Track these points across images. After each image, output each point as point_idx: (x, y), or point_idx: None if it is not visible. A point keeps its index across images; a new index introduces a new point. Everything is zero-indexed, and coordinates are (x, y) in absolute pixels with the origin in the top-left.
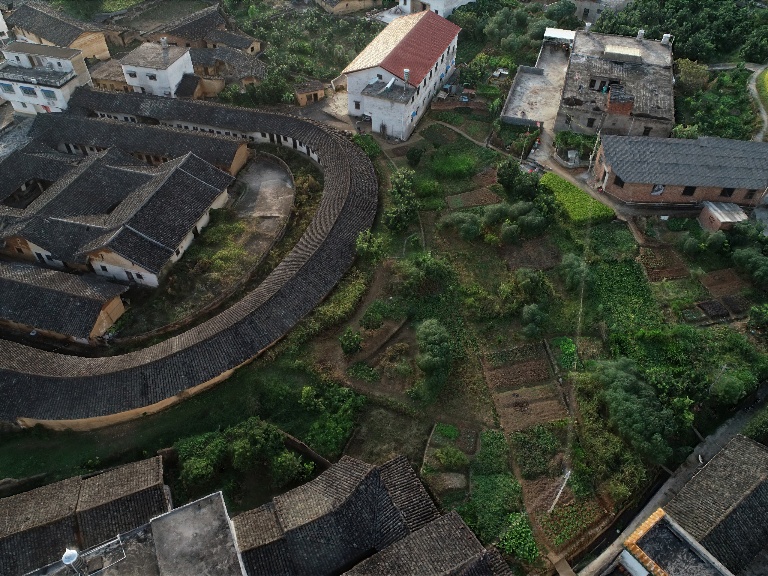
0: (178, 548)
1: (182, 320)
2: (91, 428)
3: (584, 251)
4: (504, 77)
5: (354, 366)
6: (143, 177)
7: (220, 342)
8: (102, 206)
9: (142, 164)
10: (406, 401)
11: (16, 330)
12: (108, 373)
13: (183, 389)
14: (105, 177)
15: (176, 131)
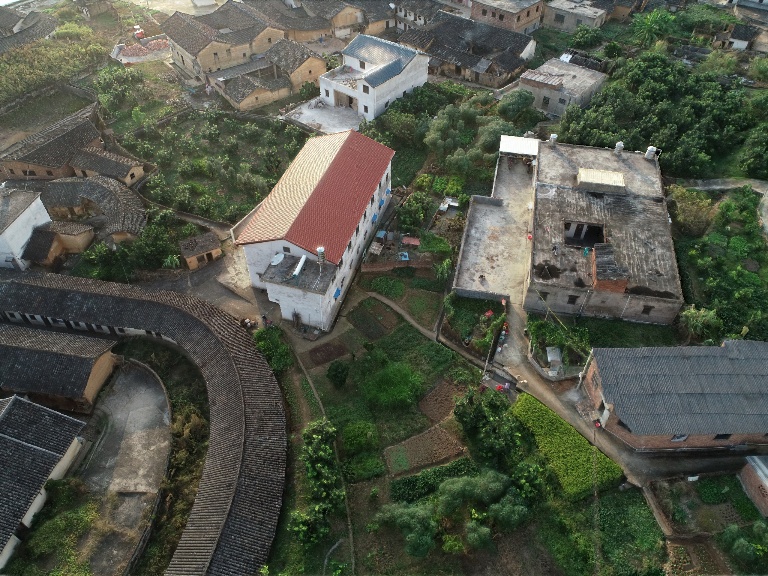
0: None
1: None
2: None
3: (588, 559)
4: (453, 209)
5: None
6: None
7: None
8: None
9: None
10: None
11: None
12: None
13: None
14: None
15: (5, 344)
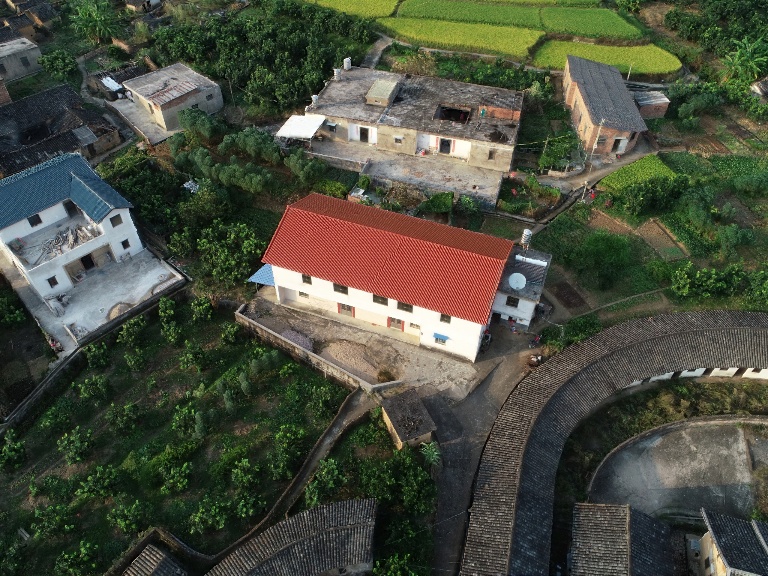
0: None
1: None
2: None
3: None
4: None
5: None
6: None
7: None
8: None
9: None
10: None
11: None
12: None
13: None
14: None
15: None
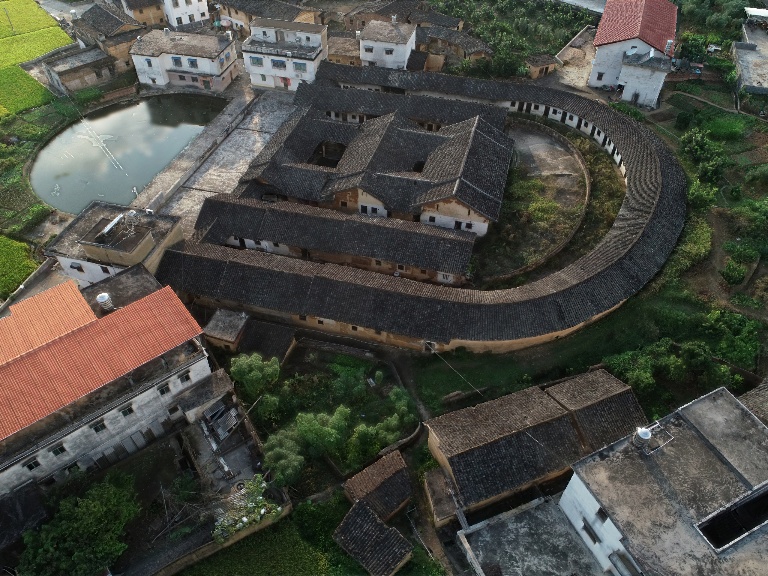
0: (719, 430)
1: (539, 261)
2: (508, 350)
3: None
4: (716, 53)
5: (736, 296)
6: (437, 139)
7: (612, 275)
8: (408, 164)
9: (422, 128)
10: None
11: None
12: (526, 300)
13: (593, 315)
14: (400, 139)
15: (444, 99)
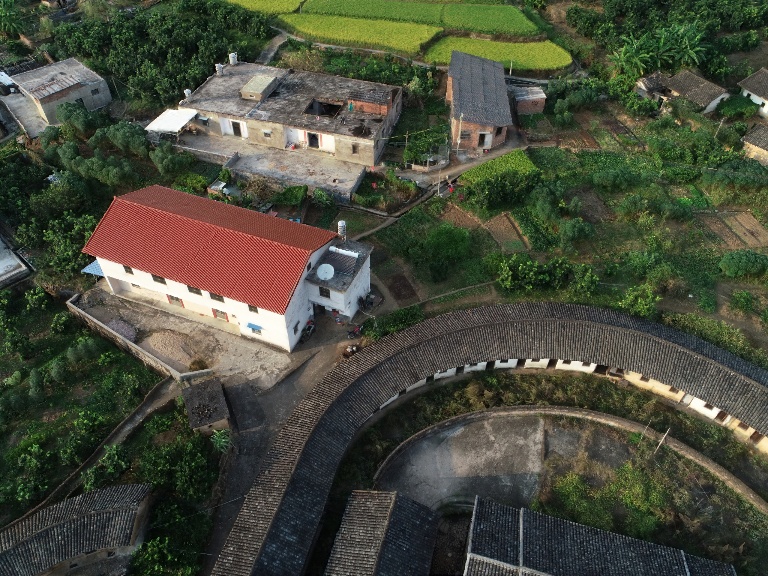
0: None
1: None
2: None
3: None
4: None
5: None
6: None
7: None
8: None
9: None
10: None
11: None
12: None
13: None
14: None
15: None
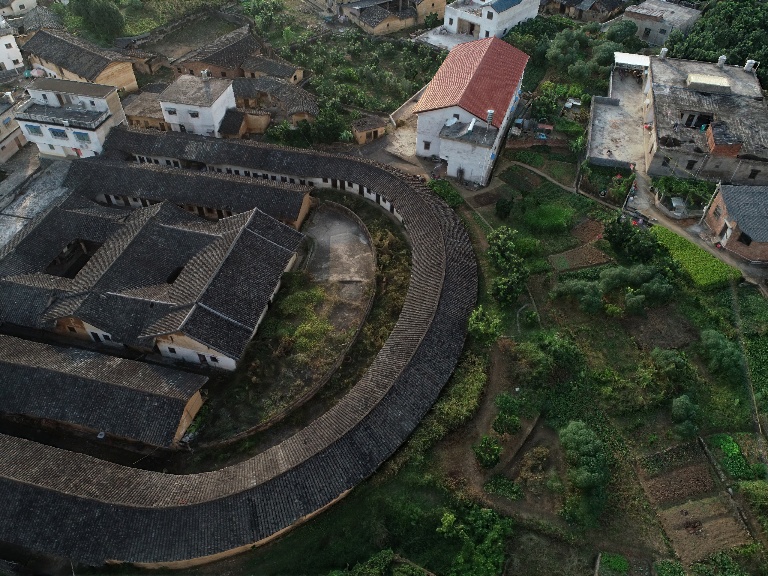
0: None
1: (275, 418)
2: (190, 565)
3: (720, 323)
4: (576, 108)
5: (492, 480)
6: (204, 238)
7: (335, 455)
8: (161, 274)
9: (198, 220)
10: (560, 524)
11: (79, 430)
12: (210, 501)
13: (298, 517)
14: (161, 238)
15: (232, 180)
